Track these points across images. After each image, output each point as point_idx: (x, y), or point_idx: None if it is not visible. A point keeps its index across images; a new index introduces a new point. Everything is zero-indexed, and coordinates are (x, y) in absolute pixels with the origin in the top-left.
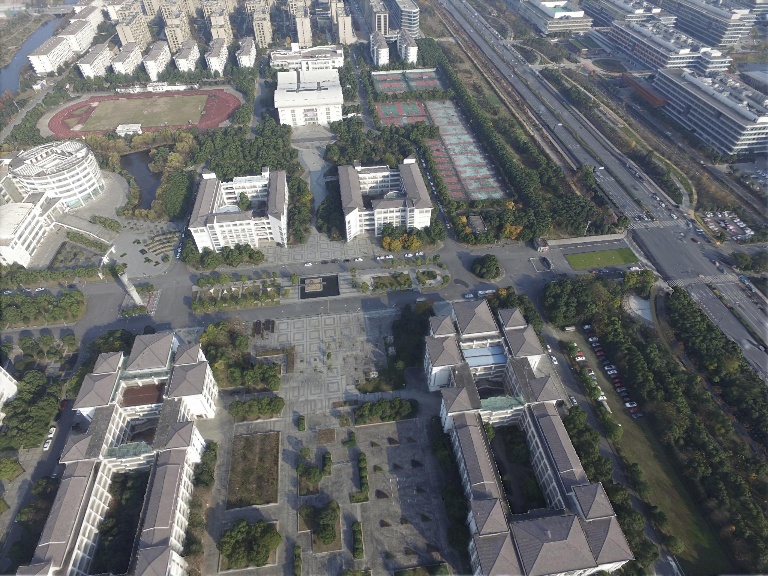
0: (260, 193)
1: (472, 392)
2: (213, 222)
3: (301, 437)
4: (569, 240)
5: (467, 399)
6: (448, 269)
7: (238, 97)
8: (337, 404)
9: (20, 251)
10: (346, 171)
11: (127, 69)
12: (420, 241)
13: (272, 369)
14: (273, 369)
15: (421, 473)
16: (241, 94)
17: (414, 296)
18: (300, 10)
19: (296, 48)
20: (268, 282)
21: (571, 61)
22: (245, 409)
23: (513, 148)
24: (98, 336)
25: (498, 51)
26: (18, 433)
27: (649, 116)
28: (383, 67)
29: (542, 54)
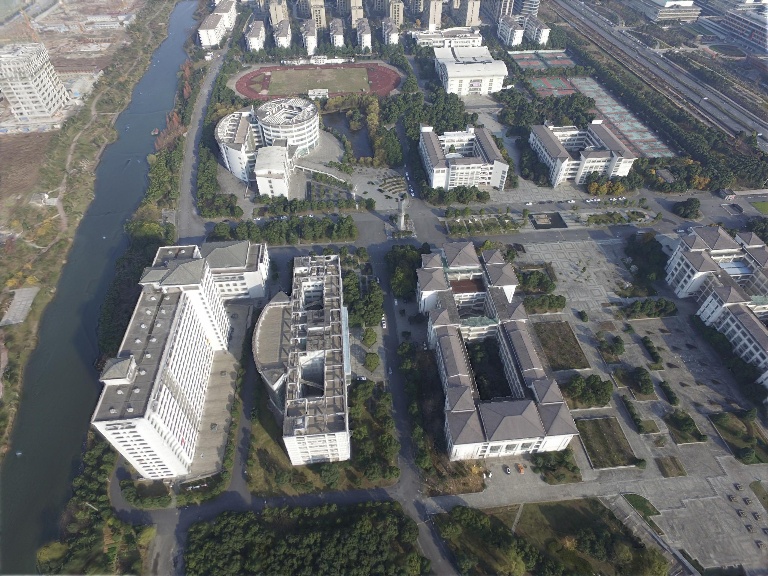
0: (465, 147)
1: (739, 290)
2: (456, 164)
3: (587, 326)
4: (749, 191)
5: (738, 294)
6: (652, 211)
7: (394, 70)
8: (606, 304)
9: (285, 185)
10: (542, 129)
11: (288, 43)
12: (623, 187)
13: (546, 276)
14: None
15: (698, 353)
16: (396, 68)
17: (632, 230)
18: None
19: (433, 29)
20: None
21: (689, 46)
22: (539, 303)
23: None
24: (379, 251)
25: (616, 36)
26: (367, 312)
27: None
28: (518, 47)
29: (659, 39)
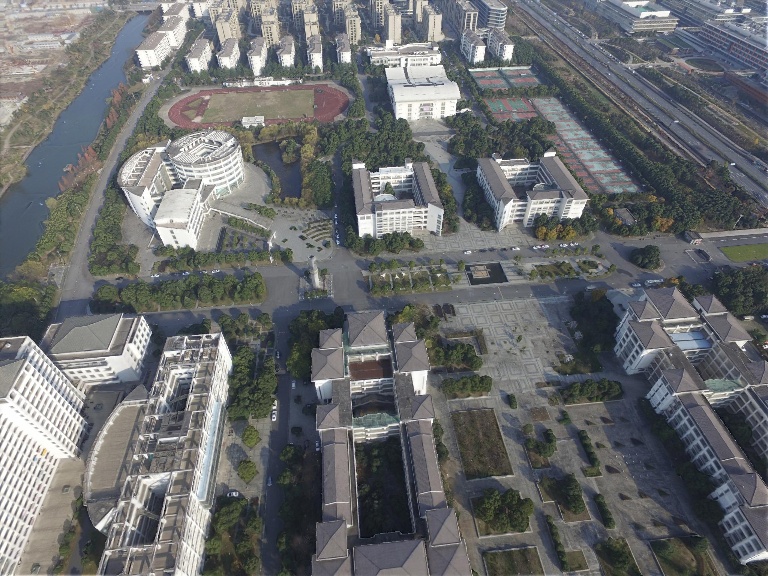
0: (403, 183)
1: (693, 374)
2: (382, 209)
3: (515, 414)
4: (718, 233)
5: (691, 380)
6: (607, 259)
7: (344, 92)
8: (541, 384)
9: (192, 235)
10: (489, 163)
11: (232, 64)
12: (575, 232)
13: (472, 350)
14: (472, 350)
15: (644, 451)
16: (346, 89)
17: (582, 284)
18: (390, 8)
19: (390, 45)
20: (434, 268)
21: (664, 60)
22: (459, 386)
23: (634, 144)
24: (287, 316)
25: (587, 50)
26: (251, 403)
27: (762, 114)
28: (480, 64)
29: (633, 53)
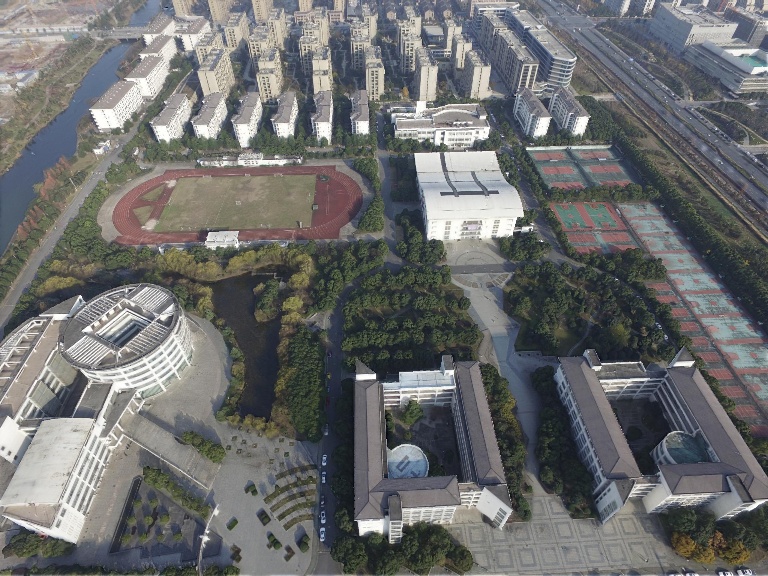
0: (437, 397)
1: None
2: (401, 515)
3: None
4: None
5: None
6: None
7: (357, 181)
8: None
9: (69, 520)
10: (581, 375)
11: (212, 132)
12: (748, 551)
13: None
14: None
15: None
16: (360, 176)
17: None
18: (423, 54)
19: (422, 107)
20: None
21: None
22: None
23: None
24: None
25: (682, 118)
26: None
27: None
28: (541, 141)
29: (747, 127)
